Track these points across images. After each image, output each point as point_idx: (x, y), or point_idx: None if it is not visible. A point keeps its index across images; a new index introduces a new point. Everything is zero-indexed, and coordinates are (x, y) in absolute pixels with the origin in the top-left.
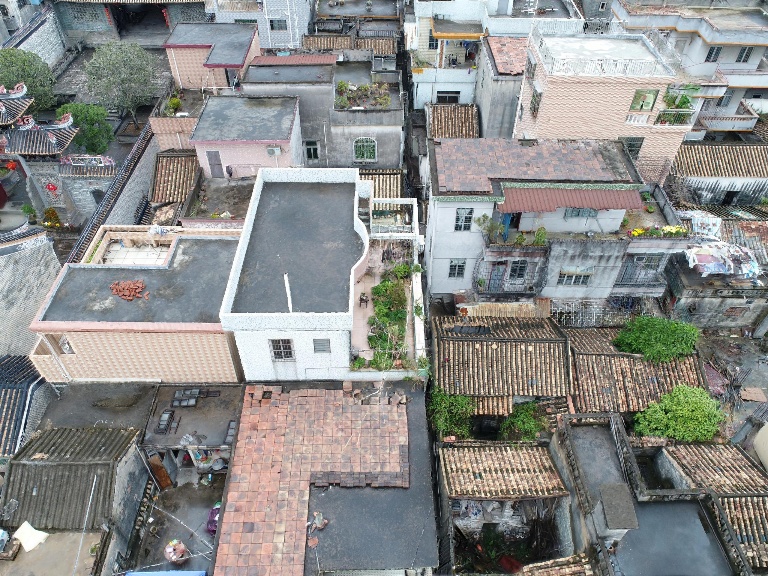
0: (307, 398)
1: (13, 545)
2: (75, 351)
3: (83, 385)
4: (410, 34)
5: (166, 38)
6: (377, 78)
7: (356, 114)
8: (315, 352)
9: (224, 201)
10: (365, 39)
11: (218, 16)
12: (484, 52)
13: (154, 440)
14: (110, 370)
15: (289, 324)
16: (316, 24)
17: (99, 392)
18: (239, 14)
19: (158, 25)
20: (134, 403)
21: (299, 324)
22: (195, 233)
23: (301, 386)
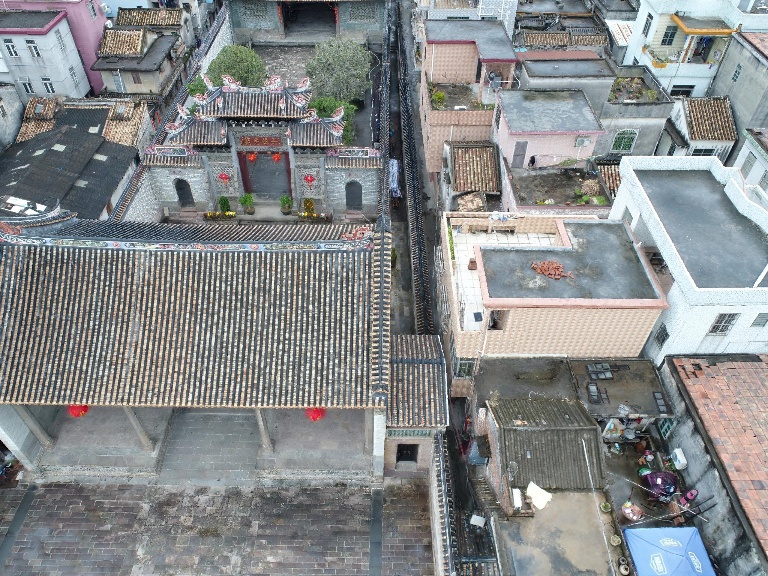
0: (737, 370)
1: (525, 503)
2: (507, 327)
3: (495, 360)
4: (616, 31)
5: (426, 34)
6: (622, 73)
7: (628, 107)
8: (750, 326)
9: (535, 189)
10: (578, 36)
11: (432, 13)
12: (747, 47)
13: (594, 409)
14: (525, 346)
15: (752, 298)
16: (520, 21)
17: (514, 366)
18: (453, 11)
19: (314, 23)
20: (553, 376)
21: (761, 298)
22: (533, 219)
23: (721, 359)
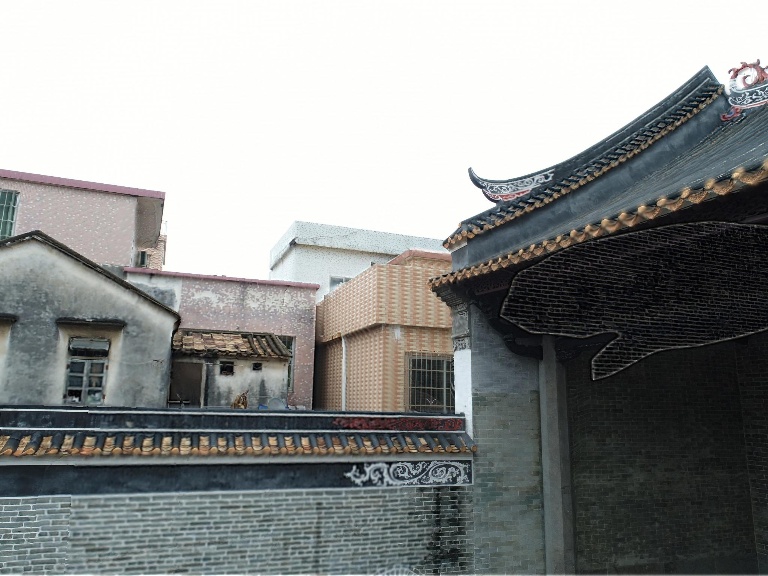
0: None
1: None
2: None
3: None
4: None
5: None
6: None
7: None
8: None
9: None
10: None
11: None
12: None
13: None
14: None
15: None
16: None
17: None
18: None
19: None
20: None
21: None
22: None
23: None
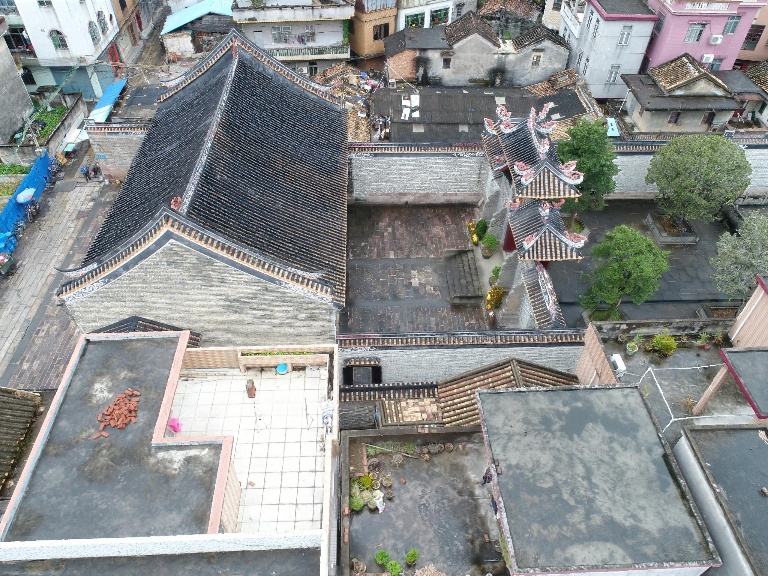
0: None
1: None
2: None
3: None
4: None
5: None
6: None
7: None
8: None
9: (427, 487)
10: None
11: None
12: None
13: None
14: None
15: None
16: None
17: None
18: None
19: None
20: None
21: None
22: None
23: None
